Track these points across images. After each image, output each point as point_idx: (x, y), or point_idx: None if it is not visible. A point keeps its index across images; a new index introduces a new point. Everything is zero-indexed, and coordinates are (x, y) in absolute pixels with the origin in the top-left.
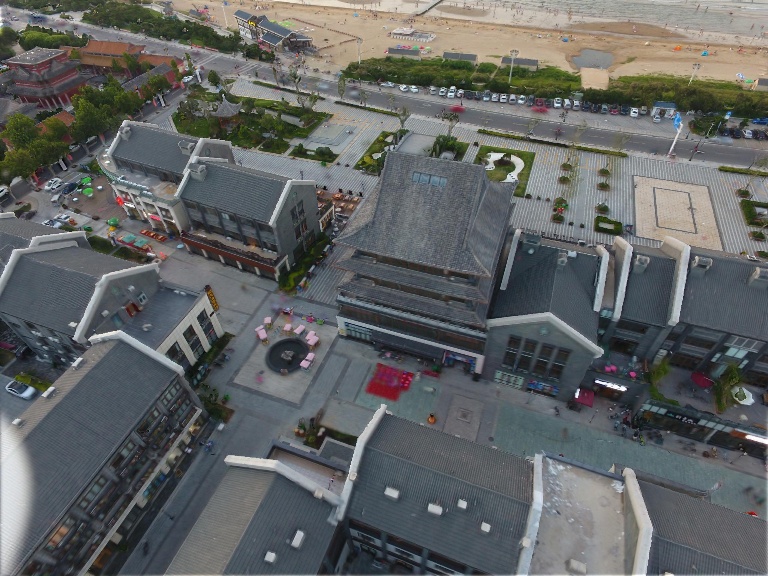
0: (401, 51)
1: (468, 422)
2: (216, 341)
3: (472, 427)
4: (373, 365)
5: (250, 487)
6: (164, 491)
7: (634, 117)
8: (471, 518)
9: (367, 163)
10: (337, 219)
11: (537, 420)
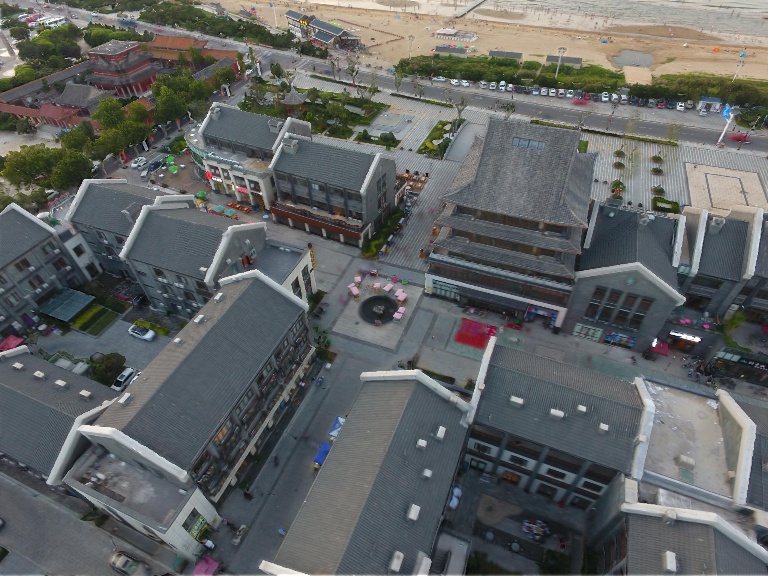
0: (448, 49)
1: None
2: (311, 296)
3: None
4: (458, 319)
5: (392, 393)
6: (285, 416)
7: (680, 111)
8: (589, 421)
9: (429, 148)
10: (408, 196)
11: (616, 367)
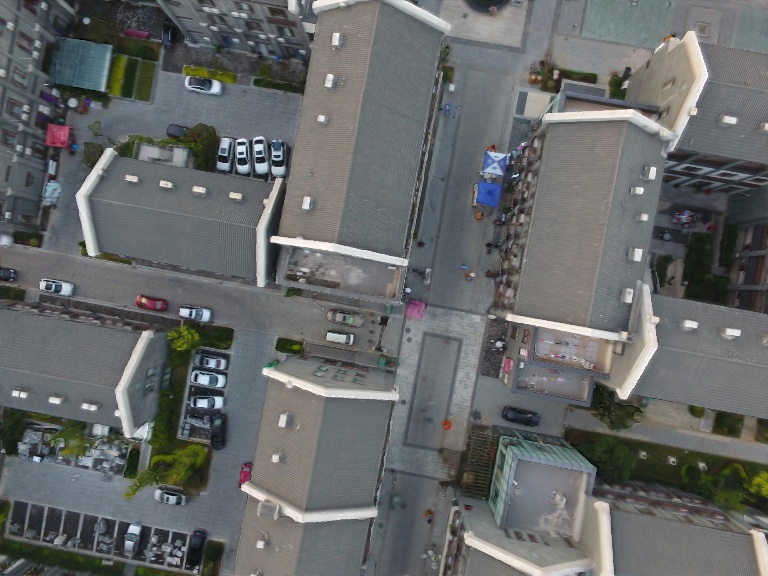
0: None
1: (706, 37)
2: None
3: (711, 42)
4: None
5: (595, 139)
6: None
7: None
8: None
9: None
10: None
11: None
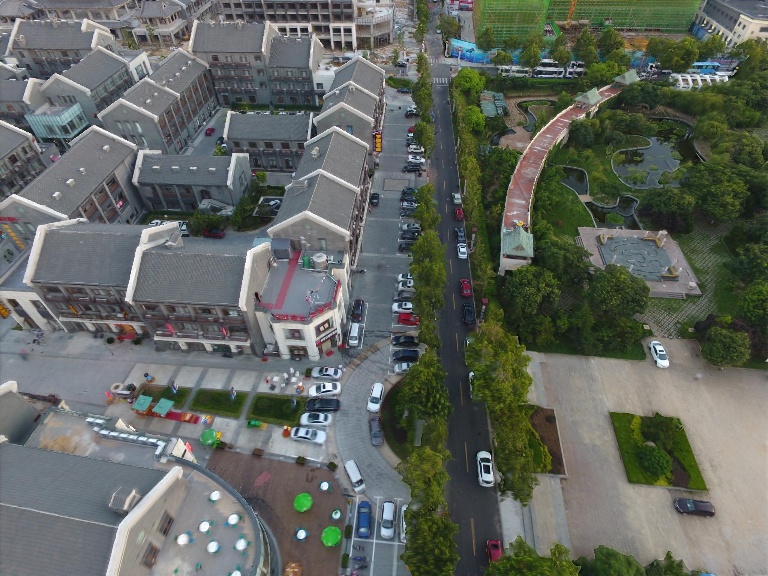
0: None
1: None
2: None
3: None
4: None
5: None
6: None
7: None
8: None
9: None
10: None
11: None
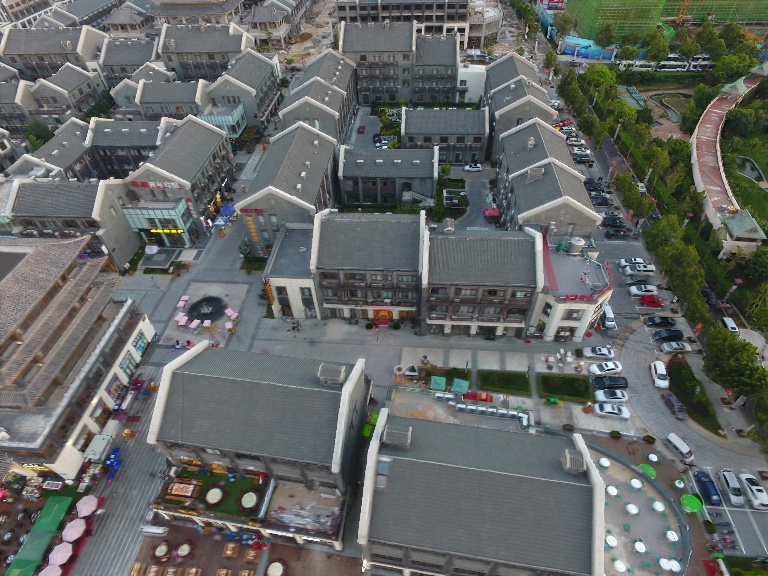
0: None
1: None
2: None
3: None
4: None
5: (166, 169)
6: None
7: None
8: None
9: None
10: None
11: None
